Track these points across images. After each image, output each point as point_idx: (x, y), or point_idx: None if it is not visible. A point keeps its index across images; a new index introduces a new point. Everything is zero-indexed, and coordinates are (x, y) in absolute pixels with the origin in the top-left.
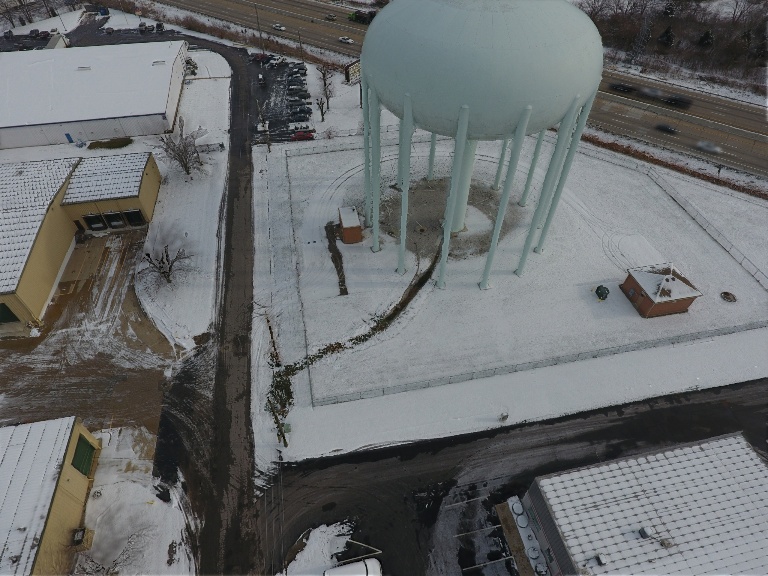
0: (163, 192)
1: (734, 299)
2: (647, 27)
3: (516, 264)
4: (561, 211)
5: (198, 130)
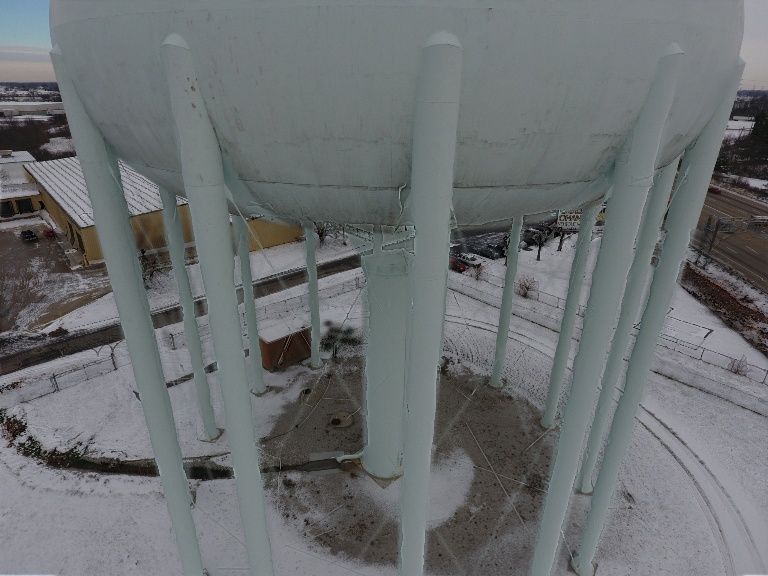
0: (285, 245)
1: None
2: None
3: None
4: None
5: None
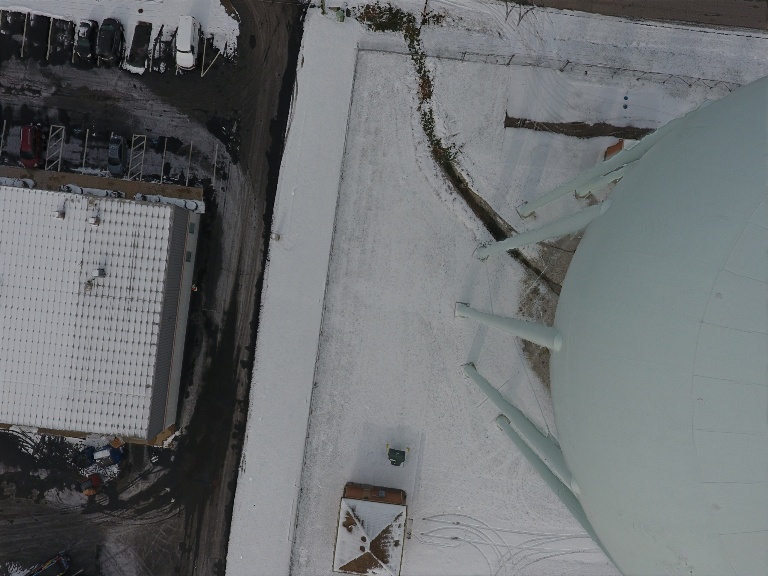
0: None
1: None
2: None
3: (486, 375)
4: None
5: None
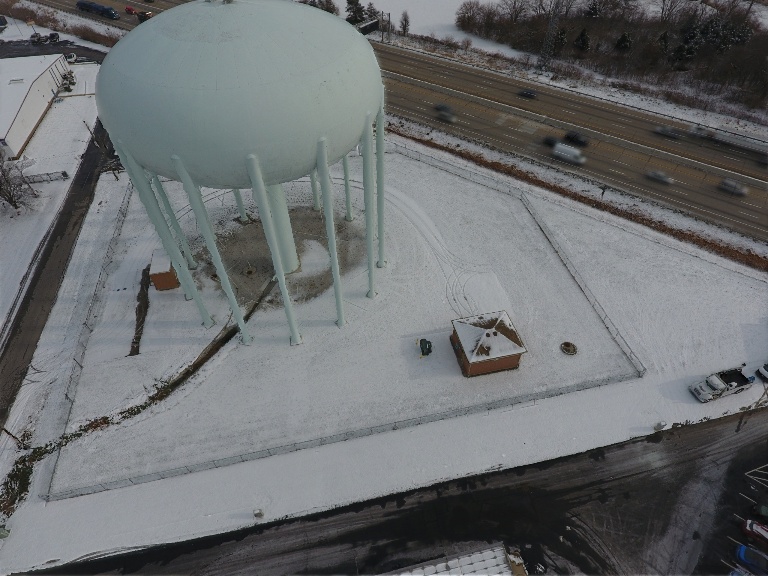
0: None
1: (574, 351)
2: (553, 31)
3: None
4: (412, 245)
5: (23, 160)
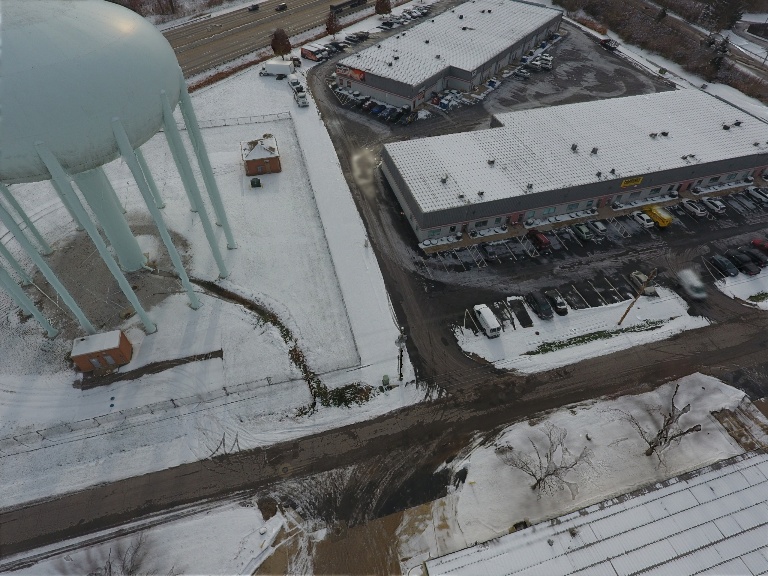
0: None
1: (270, 134)
2: None
3: None
4: None
5: None
